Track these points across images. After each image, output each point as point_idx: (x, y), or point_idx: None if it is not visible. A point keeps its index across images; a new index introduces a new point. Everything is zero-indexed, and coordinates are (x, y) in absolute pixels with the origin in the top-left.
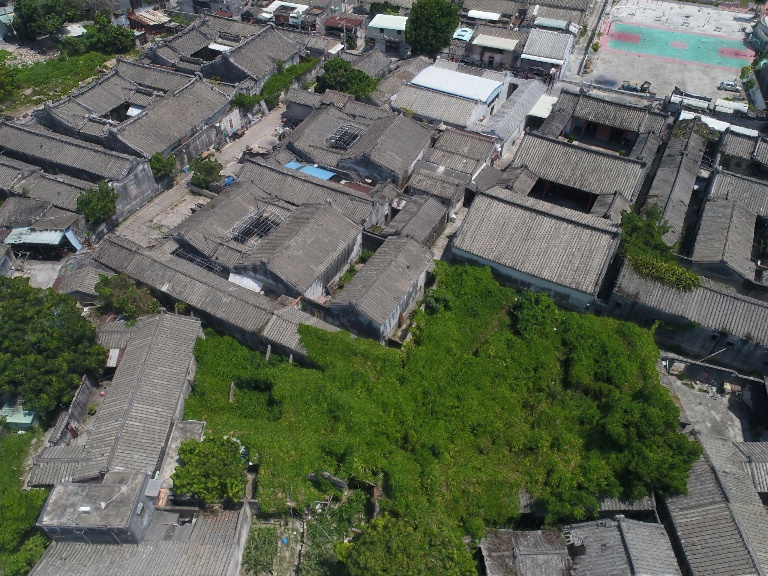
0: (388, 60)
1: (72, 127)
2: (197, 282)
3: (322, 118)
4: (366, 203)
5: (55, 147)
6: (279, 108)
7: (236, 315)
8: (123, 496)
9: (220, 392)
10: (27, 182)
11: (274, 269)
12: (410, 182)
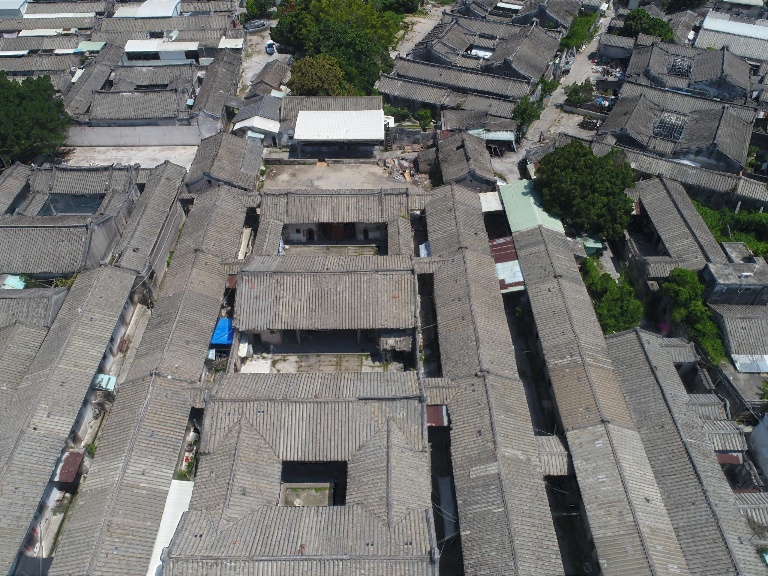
0: (663, 13)
1: (450, 62)
2: (660, 160)
3: (653, 54)
4: (748, 109)
5: (453, 75)
6: (581, 53)
7: (706, 181)
8: (760, 270)
9: (715, 233)
10: (451, 99)
11: (721, 150)
12: (762, 98)
